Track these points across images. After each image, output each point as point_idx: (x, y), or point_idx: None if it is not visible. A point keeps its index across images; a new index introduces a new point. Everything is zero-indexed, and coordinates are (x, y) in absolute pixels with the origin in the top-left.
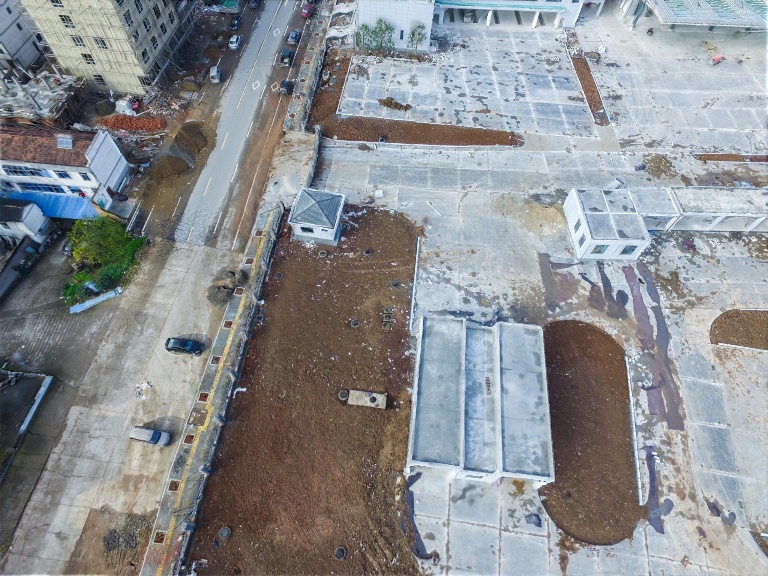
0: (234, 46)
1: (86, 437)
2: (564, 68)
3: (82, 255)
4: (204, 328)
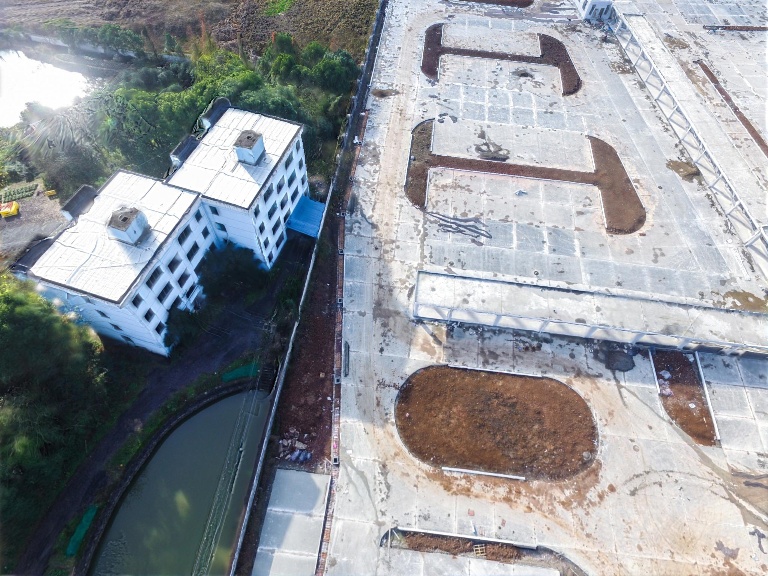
0: None
1: None
2: (763, 23)
3: None
4: None
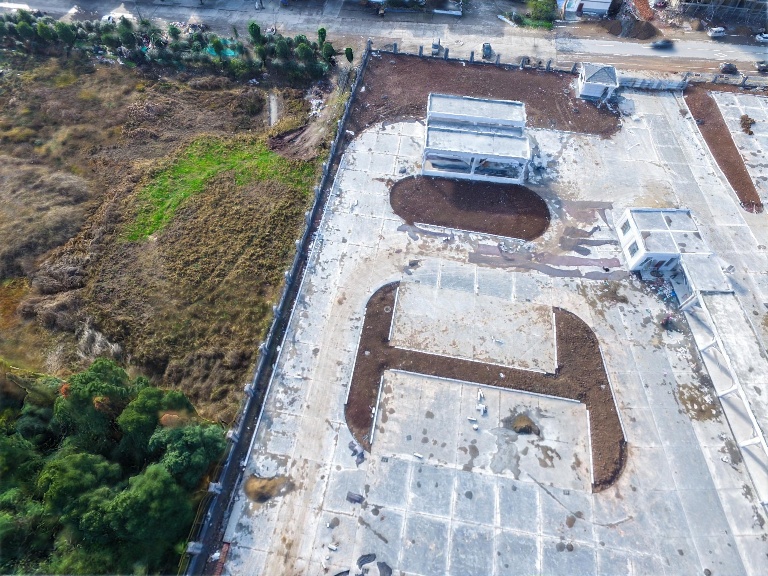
0: (759, 37)
1: (433, 31)
2: None
3: None
4: (500, 58)
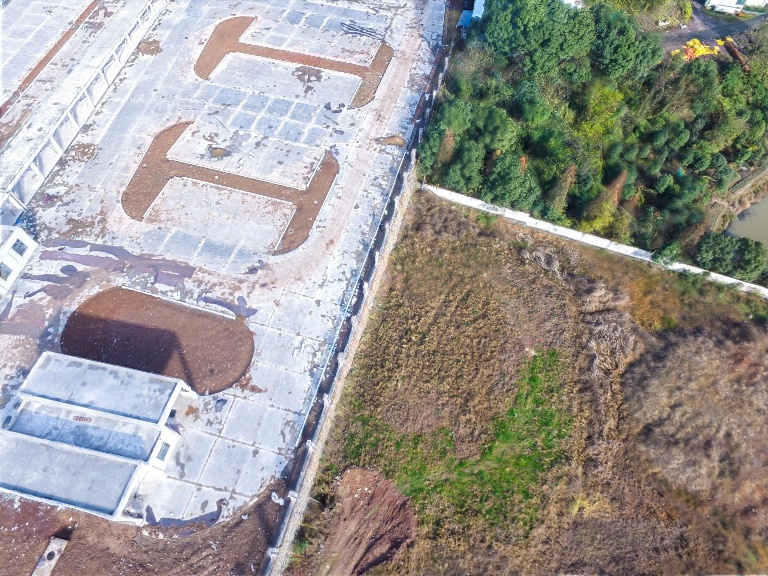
0: None
1: None
2: None
3: None
4: None
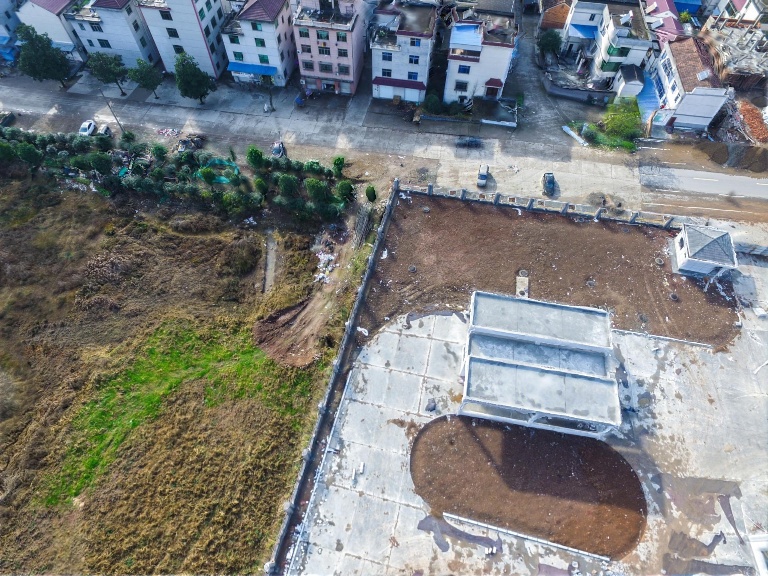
0: None
1: (480, 149)
2: None
3: (609, 122)
4: (566, 194)
